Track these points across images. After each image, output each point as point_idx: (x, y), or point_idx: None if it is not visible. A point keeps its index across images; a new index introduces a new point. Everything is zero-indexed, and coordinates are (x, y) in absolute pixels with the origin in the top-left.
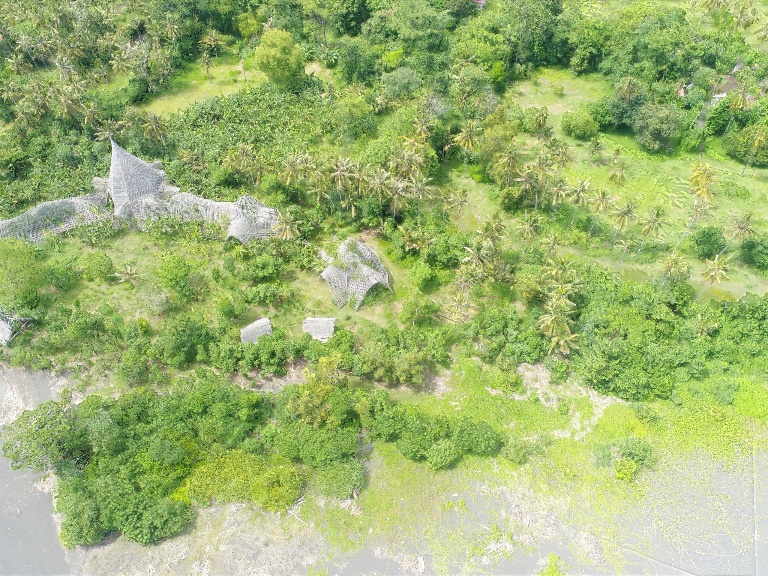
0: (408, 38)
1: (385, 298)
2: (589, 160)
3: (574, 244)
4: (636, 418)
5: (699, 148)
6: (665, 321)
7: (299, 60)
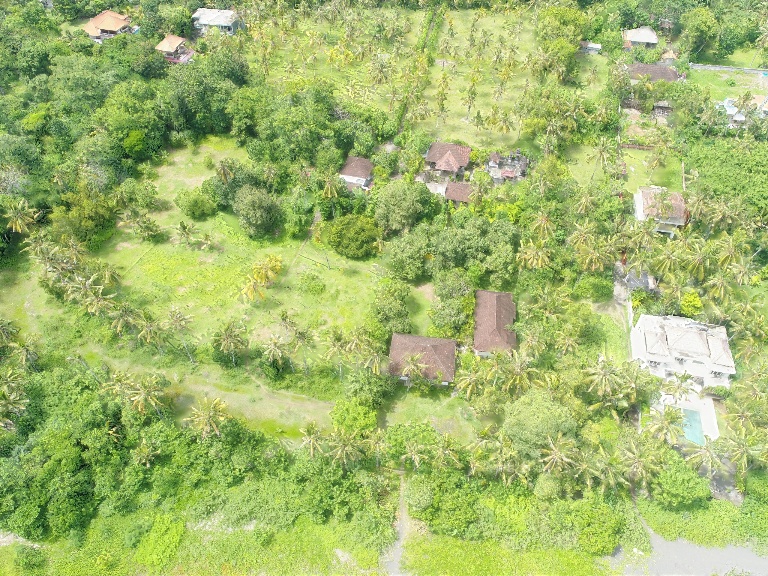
0: (71, 98)
1: None
2: (186, 243)
3: (101, 342)
4: (13, 564)
5: (308, 234)
6: (93, 447)
7: None
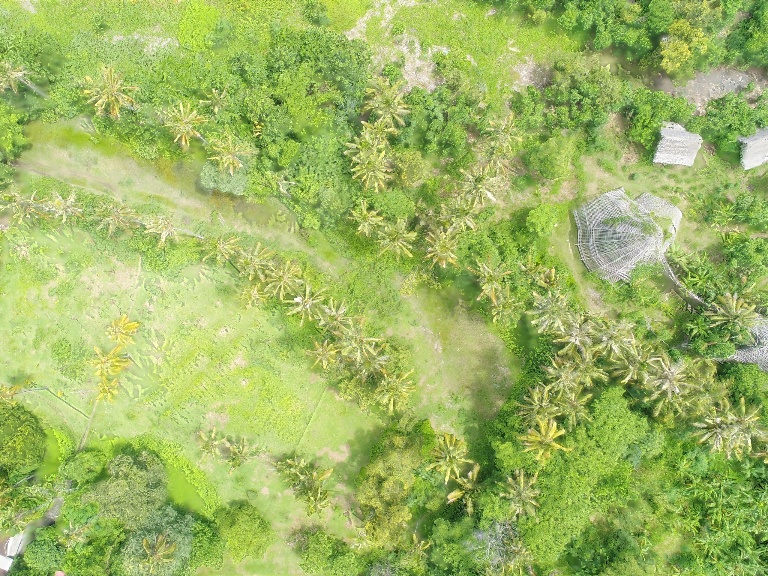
0: None
1: None
2: None
3: None
4: (327, 6)
5: None
6: None
7: None
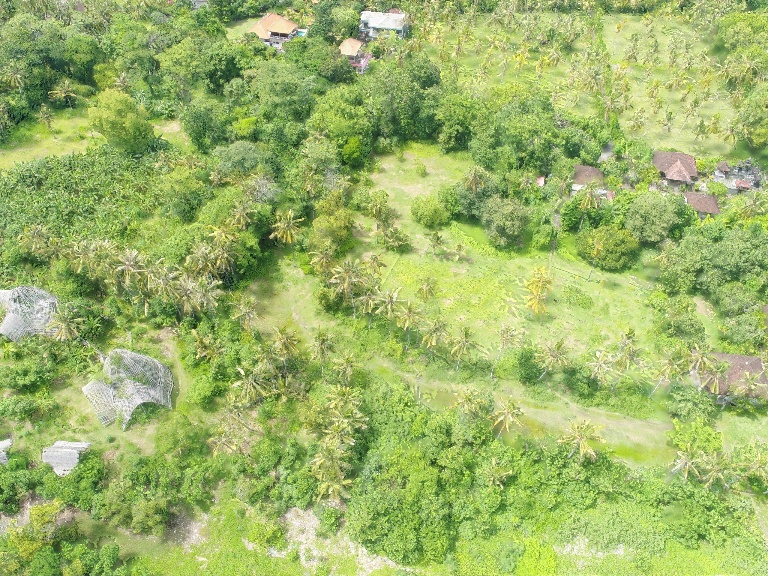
0: None
1: (162, 415)
2: (433, 253)
3: (389, 356)
4: None
5: (552, 245)
6: (451, 468)
7: (137, 124)
